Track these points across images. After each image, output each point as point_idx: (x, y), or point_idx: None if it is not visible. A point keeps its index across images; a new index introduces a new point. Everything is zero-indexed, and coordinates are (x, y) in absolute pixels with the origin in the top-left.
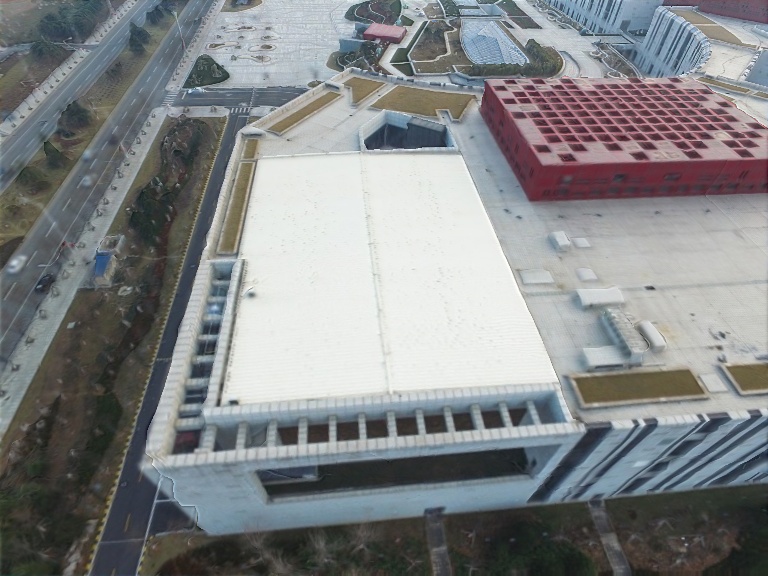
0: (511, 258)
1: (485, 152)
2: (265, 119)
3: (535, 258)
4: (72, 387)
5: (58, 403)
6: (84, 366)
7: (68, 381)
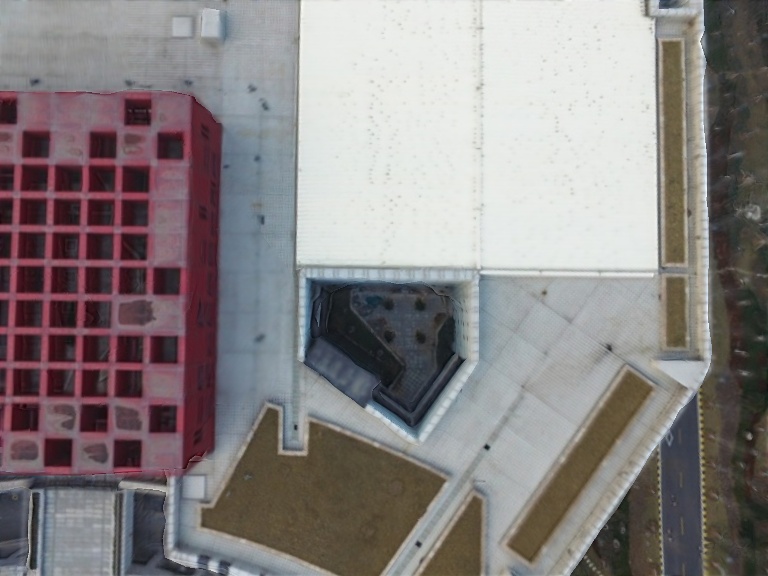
0: (292, 5)
1: (249, 279)
2: (664, 421)
3: (259, 2)
4: (760, 80)
5: (766, 64)
6: (759, 101)
7: (767, 86)
